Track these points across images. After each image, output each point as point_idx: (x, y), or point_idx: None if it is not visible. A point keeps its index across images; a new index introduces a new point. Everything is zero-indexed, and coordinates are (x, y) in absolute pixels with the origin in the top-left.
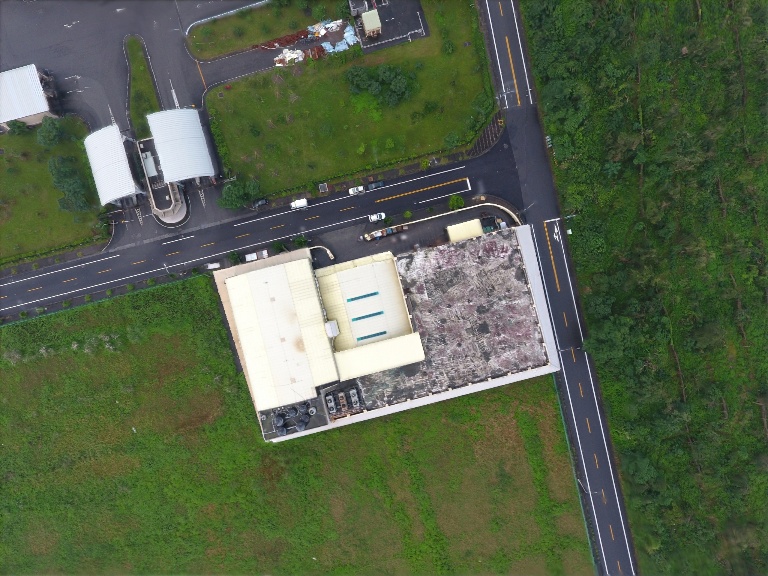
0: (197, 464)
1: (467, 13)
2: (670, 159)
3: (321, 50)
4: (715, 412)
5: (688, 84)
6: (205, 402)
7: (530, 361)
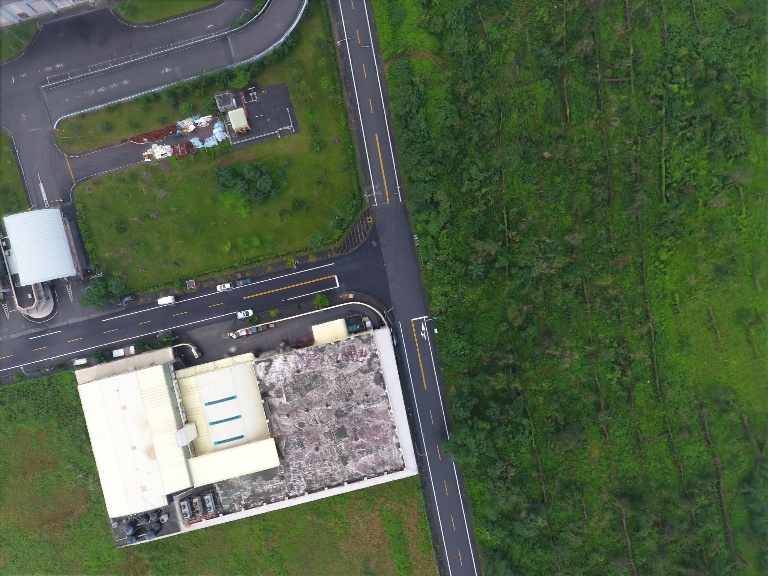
0: (61, 561)
1: (337, 110)
2: (528, 265)
3: (190, 146)
4: (575, 513)
5: (554, 185)
6: (70, 498)
7: (387, 465)
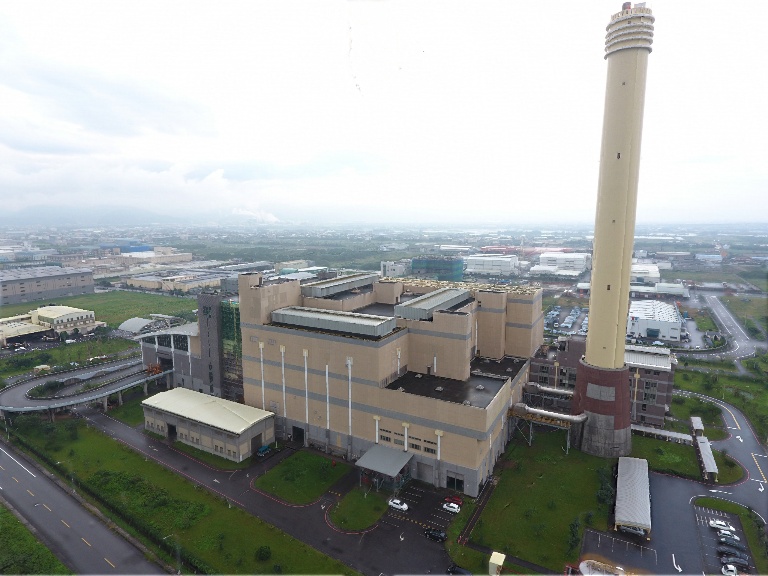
0: None
1: None
2: None
3: None
4: None
5: None
6: None
7: None
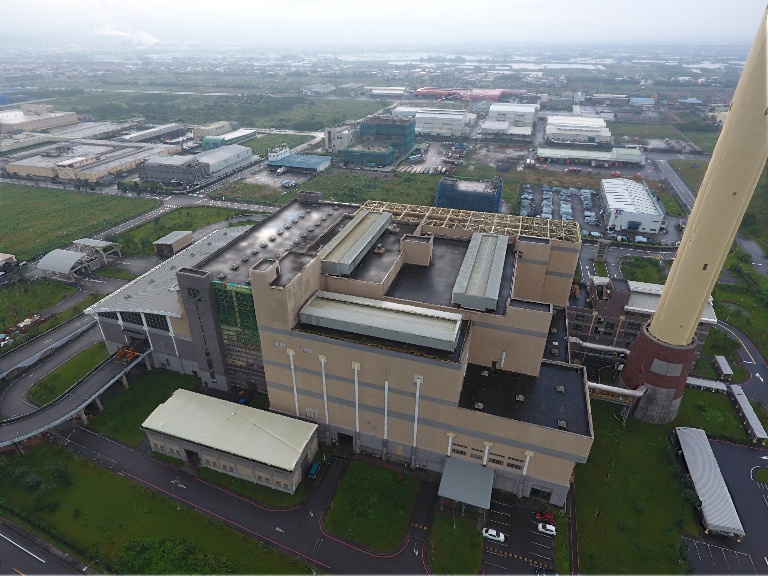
0: None
1: None
2: None
3: None
4: None
5: None
6: None
7: None
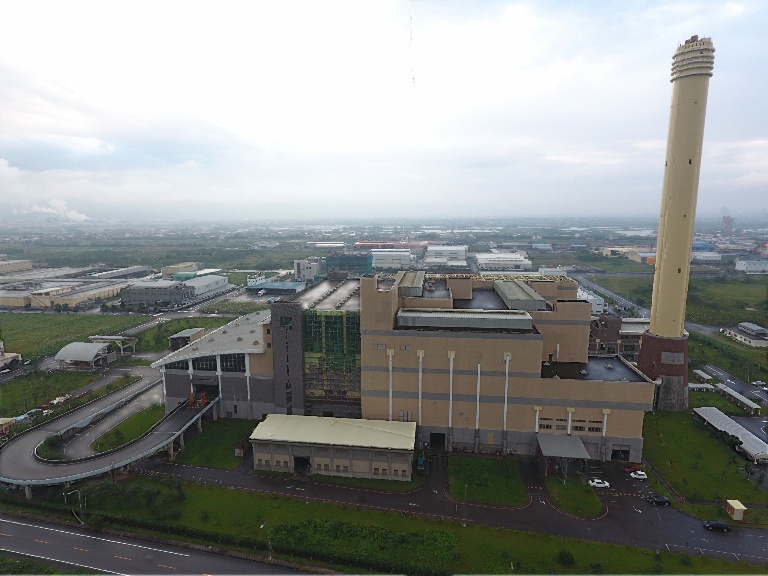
0: None
1: None
2: None
3: None
4: None
5: None
6: None
7: None
